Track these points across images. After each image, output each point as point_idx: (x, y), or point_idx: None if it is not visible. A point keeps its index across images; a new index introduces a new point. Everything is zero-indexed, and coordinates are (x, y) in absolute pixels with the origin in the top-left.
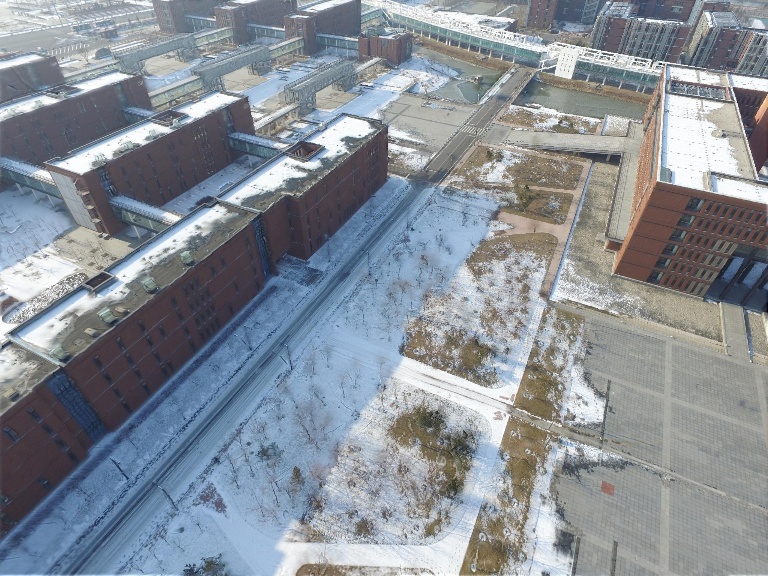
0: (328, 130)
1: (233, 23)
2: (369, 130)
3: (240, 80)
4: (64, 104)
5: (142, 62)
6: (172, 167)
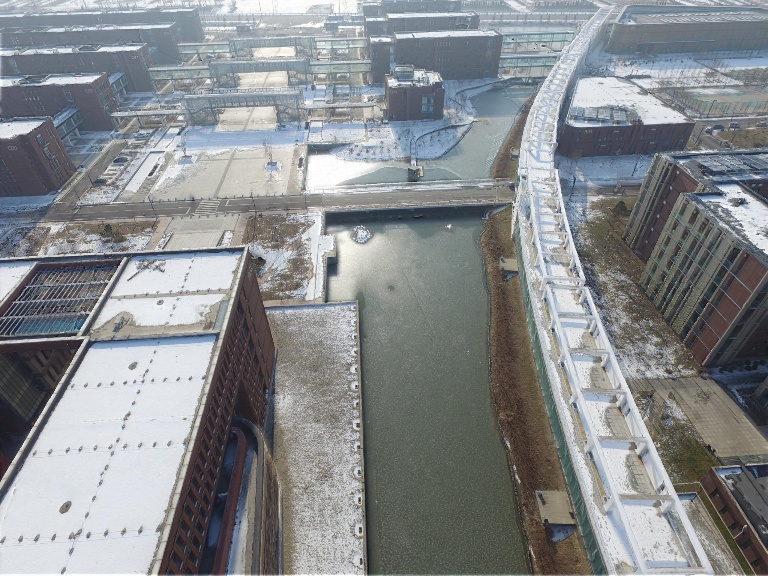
0: (7, 123)
1: (366, 35)
2: (7, 136)
3: (269, 83)
4: (67, 56)
5: (252, 49)
6: (3, 112)
